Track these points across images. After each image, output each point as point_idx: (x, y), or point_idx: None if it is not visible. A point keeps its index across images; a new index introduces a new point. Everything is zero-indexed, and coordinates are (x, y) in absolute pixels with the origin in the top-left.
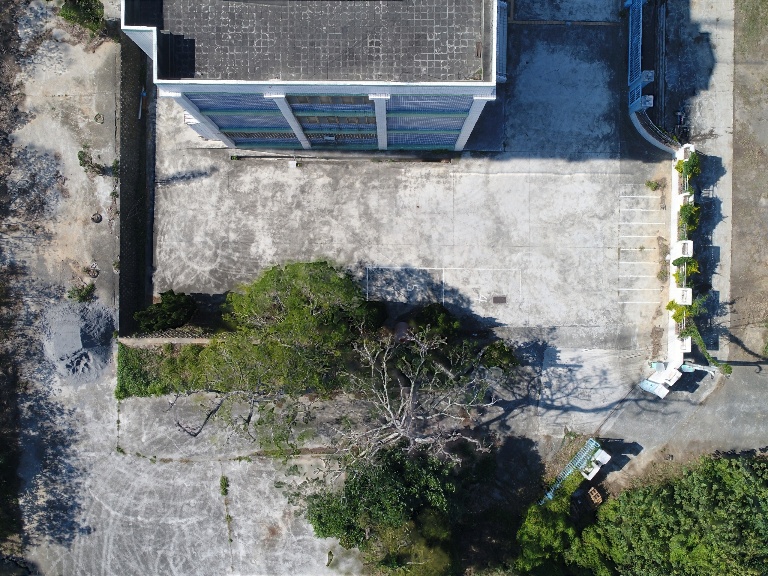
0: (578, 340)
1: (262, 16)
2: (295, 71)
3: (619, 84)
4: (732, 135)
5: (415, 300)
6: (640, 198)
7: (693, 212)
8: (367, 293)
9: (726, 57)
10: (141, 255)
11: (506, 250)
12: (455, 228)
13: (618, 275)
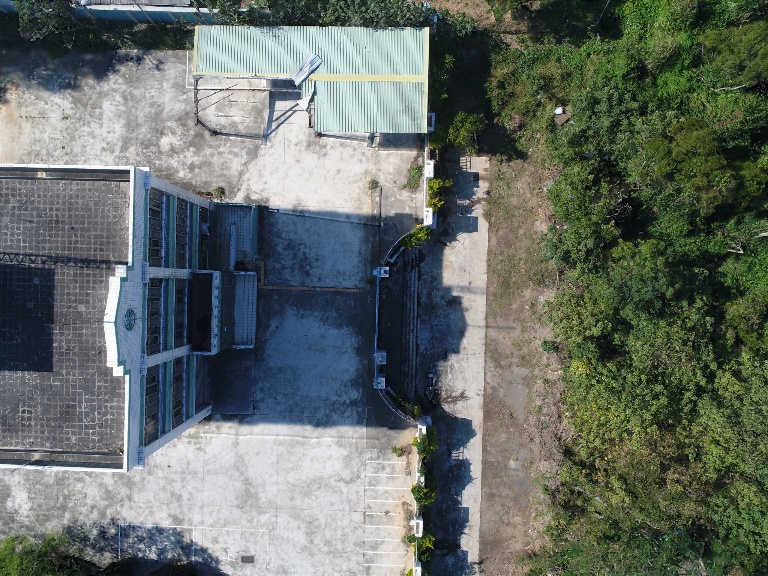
0: None
1: None
2: None
3: (367, 350)
4: (483, 398)
5: (166, 557)
6: (386, 463)
7: (422, 495)
8: (119, 549)
9: (478, 320)
10: None
11: (254, 511)
12: (205, 488)
13: (363, 538)
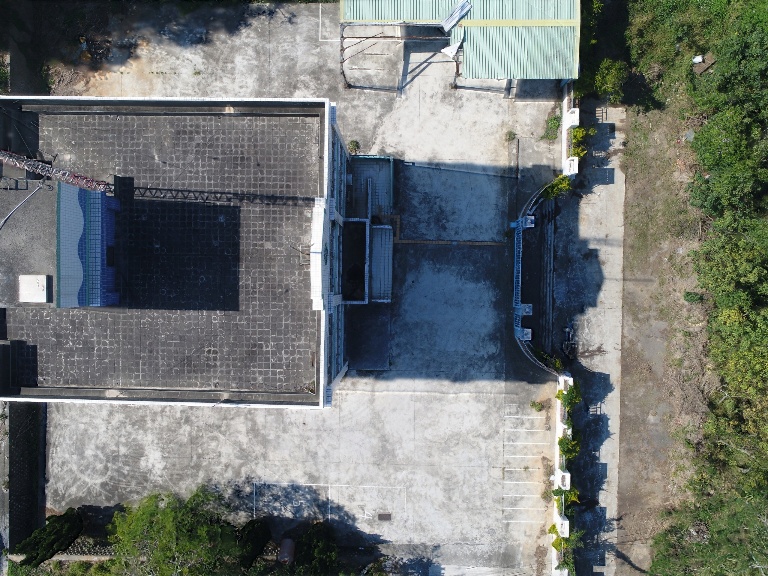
0: (462, 558)
1: (102, 323)
2: (135, 377)
3: (505, 304)
4: (620, 352)
5: (301, 516)
6: (525, 418)
7: (570, 447)
8: (254, 508)
9: (615, 273)
10: (34, 467)
11: (391, 468)
12: (341, 445)
13: (502, 494)
